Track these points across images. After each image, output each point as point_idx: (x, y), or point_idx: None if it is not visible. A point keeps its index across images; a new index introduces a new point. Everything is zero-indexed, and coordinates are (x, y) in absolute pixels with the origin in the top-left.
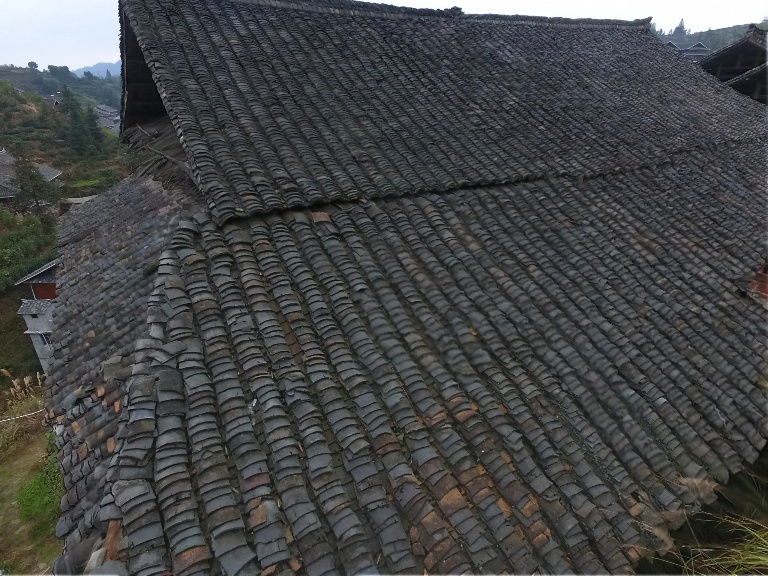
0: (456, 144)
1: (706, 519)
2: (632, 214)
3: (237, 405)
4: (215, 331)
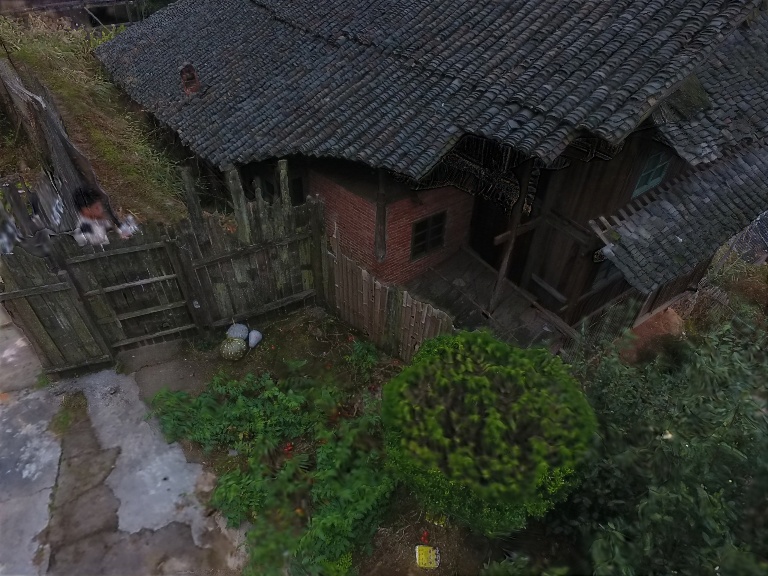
0: None
1: None
2: None
3: None
4: (177, 4)
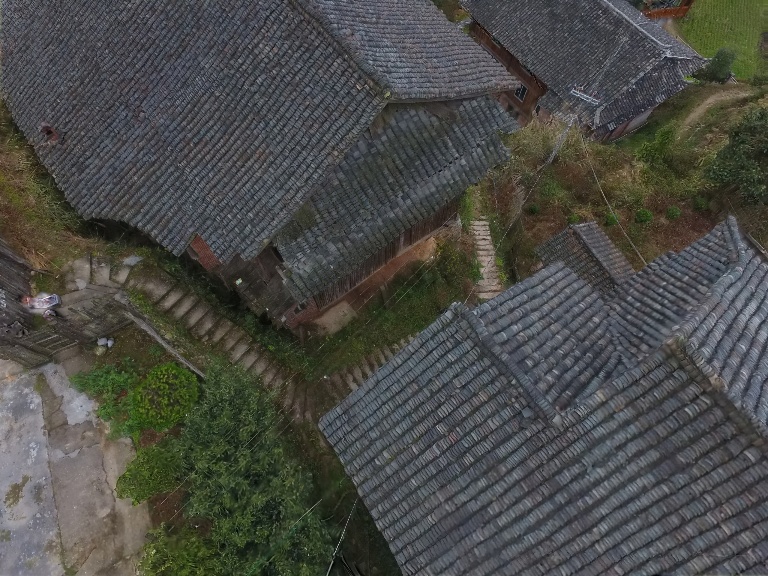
0: (97, 6)
1: (5, 107)
2: (89, 90)
3: (8, 7)
4: None
